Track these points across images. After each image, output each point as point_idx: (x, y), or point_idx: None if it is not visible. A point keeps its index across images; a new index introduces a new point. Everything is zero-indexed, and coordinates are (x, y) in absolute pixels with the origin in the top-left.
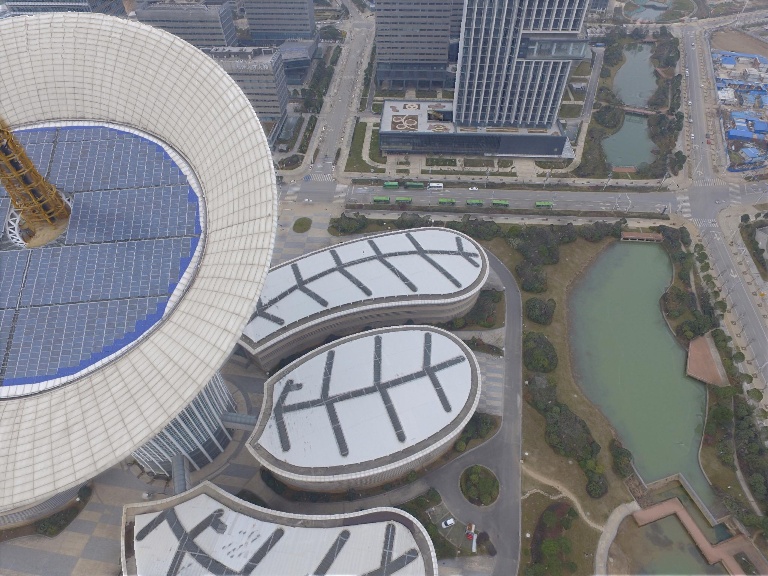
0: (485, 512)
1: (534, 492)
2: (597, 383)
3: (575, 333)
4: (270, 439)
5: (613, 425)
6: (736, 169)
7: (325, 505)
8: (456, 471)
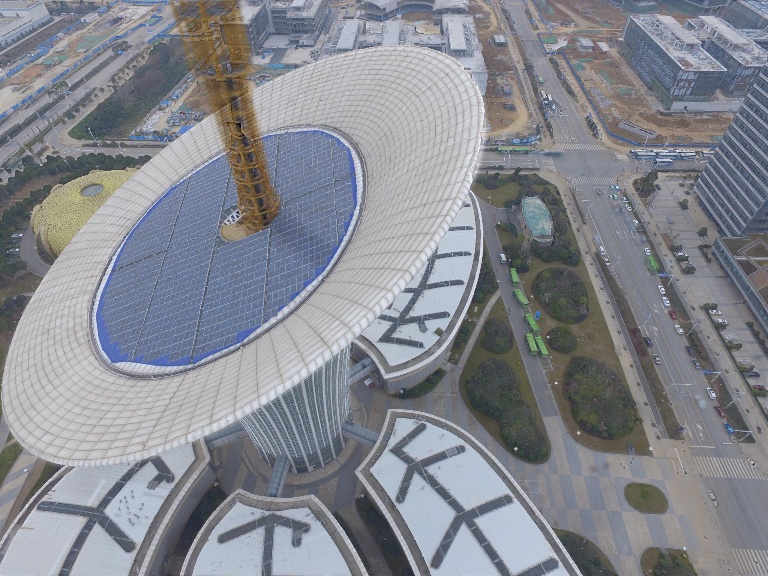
0: None
1: None
2: None
3: None
4: (237, 516)
5: None
6: None
7: None
8: None
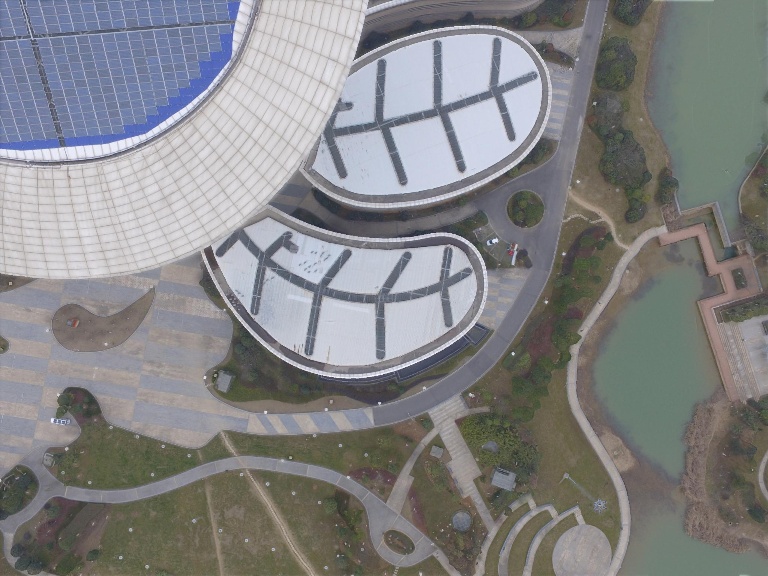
0: (527, 233)
1: (576, 216)
2: (668, 105)
3: (663, 38)
4: (325, 165)
5: (670, 153)
6: None
7: (379, 224)
8: (505, 195)
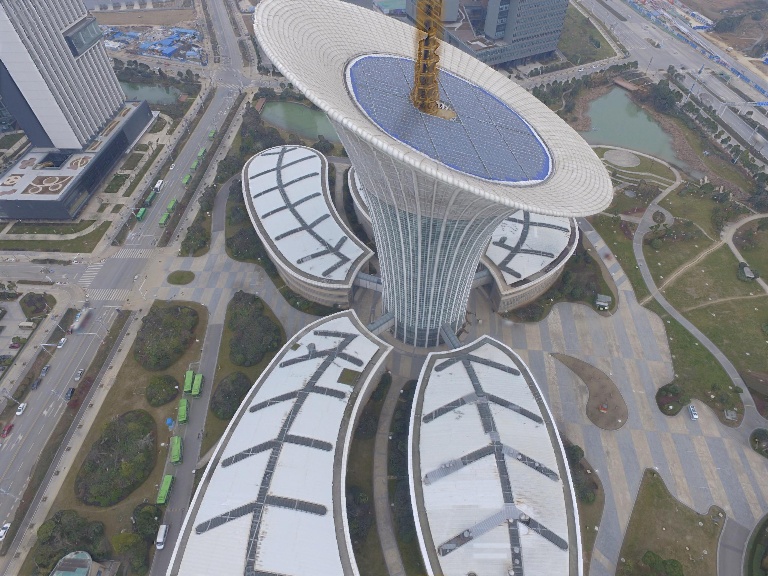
0: None
1: None
2: None
3: (338, 140)
4: None
5: None
6: (205, 63)
7: None
8: None
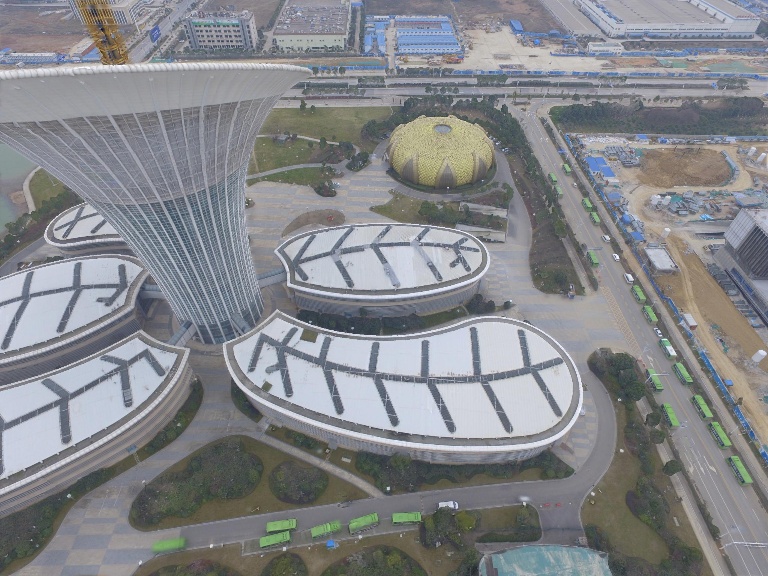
0: None
1: None
2: None
3: None
4: (133, 270)
5: None
6: None
7: None
8: None
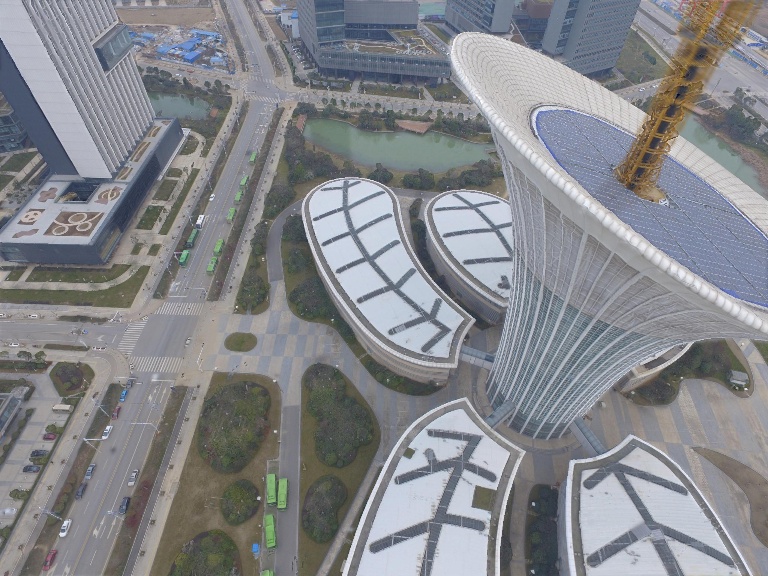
0: None
1: None
2: (434, 166)
3: (395, 168)
4: None
5: (462, 165)
6: None
7: None
8: None
